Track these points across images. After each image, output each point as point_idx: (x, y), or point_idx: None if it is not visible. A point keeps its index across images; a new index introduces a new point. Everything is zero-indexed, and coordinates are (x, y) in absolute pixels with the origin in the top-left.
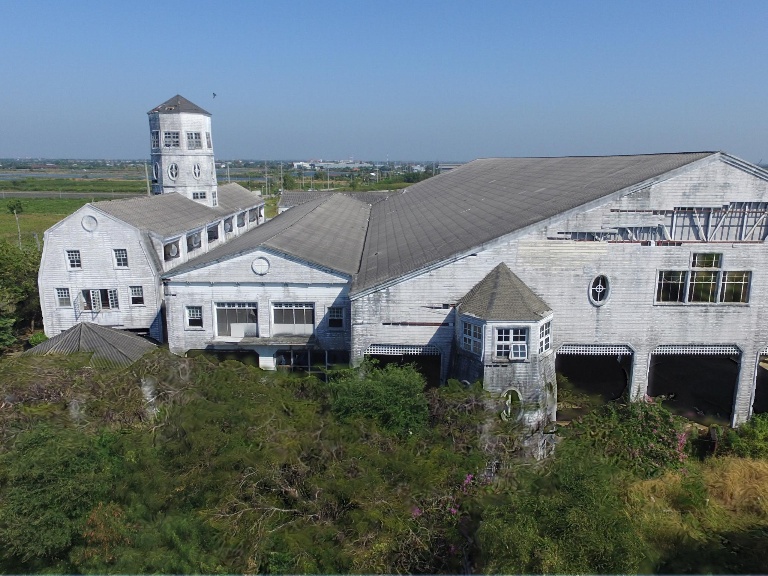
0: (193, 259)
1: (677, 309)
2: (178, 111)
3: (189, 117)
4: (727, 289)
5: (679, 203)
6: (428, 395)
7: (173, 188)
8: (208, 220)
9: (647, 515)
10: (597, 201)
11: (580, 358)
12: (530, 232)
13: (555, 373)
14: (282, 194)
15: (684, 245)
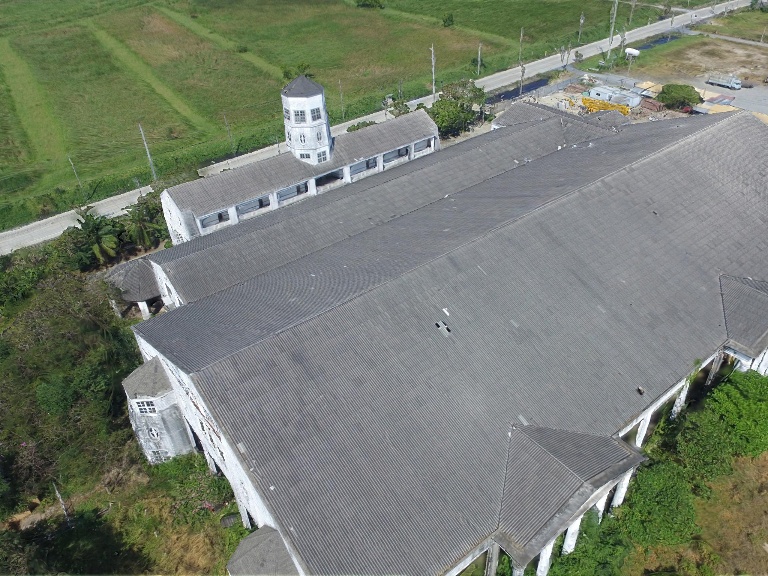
0: (197, 238)
1: None
2: (287, 96)
3: (296, 100)
4: None
5: None
6: (79, 401)
7: (290, 148)
8: (283, 185)
9: (121, 512)
10: None
11: None
12: None
13: (164, 425)
14: (511, 106)
15: None
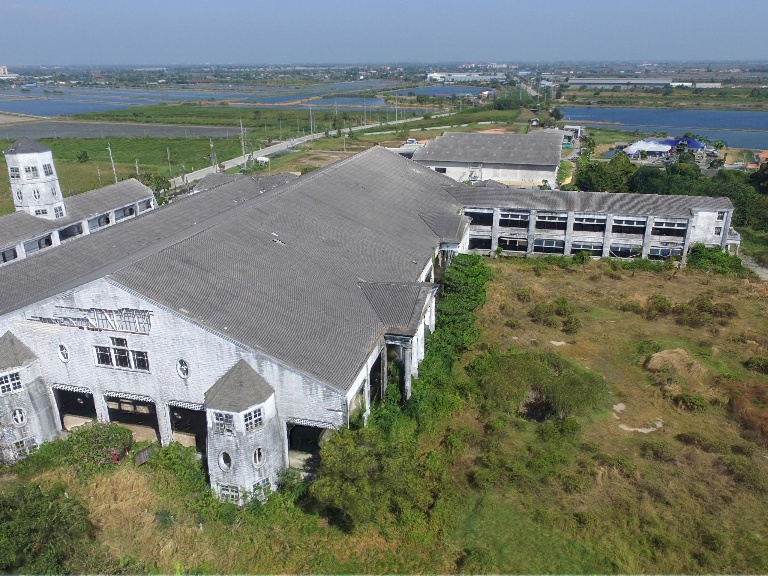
0: None
1: (110, 370)
2: (15, 153)
3: (25, 156)
4: (138, 361)
5: (92, 306)
6: None
7: (21, 207)
8: (28, 237)
9: None
10: (45, 300)
11: (65, 392)
12: (16, 315)
13: (31, 402)
14: None
15: (103, 331)
